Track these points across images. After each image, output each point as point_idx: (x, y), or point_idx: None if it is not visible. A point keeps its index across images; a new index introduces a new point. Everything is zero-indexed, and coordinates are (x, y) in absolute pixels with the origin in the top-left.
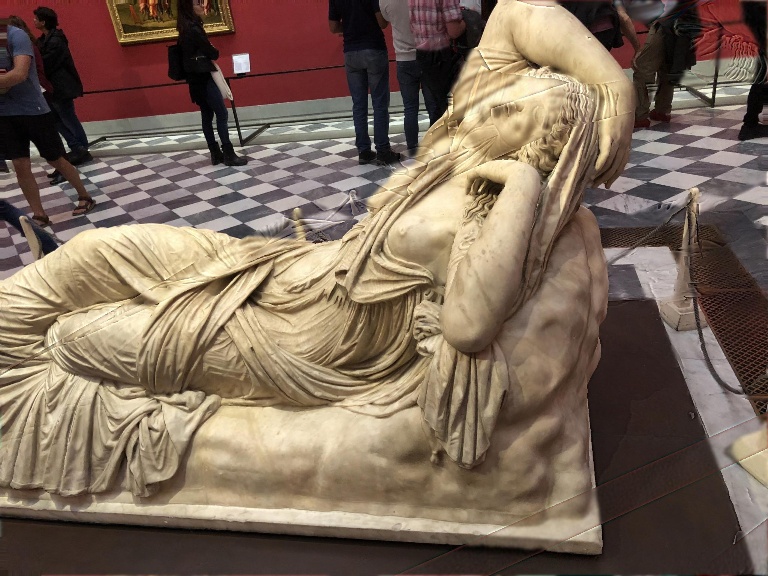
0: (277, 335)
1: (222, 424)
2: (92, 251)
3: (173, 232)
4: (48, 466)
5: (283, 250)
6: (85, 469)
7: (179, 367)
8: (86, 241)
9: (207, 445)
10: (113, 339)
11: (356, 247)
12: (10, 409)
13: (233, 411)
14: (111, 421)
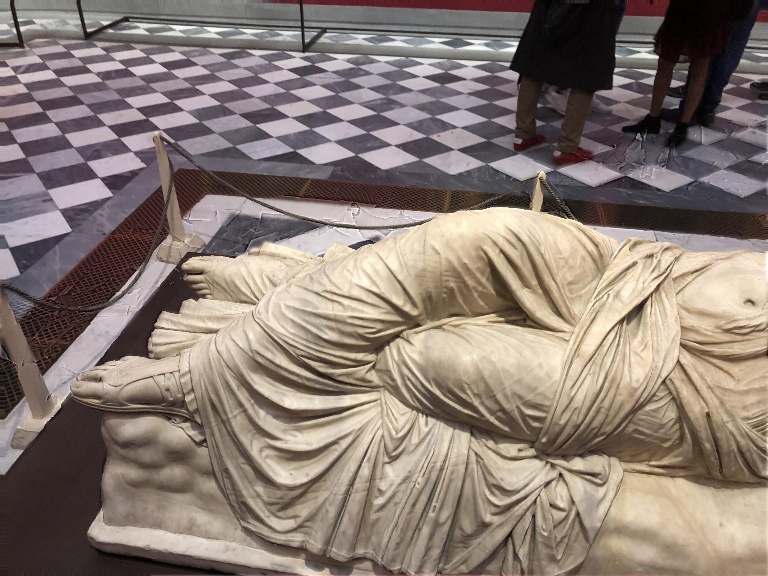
0: (721, 392)
1: (640, 504)
2: (474, 249)
3: (552, 225)
4: (399, 541)
5: (673, 260)
6: (443, 545)
7: (605, 429)
8: (466, 234)
9: (621, 531)
10: (520, 384)
11: None
12: (328, 452)
13: (641, 482)
14: (494, 490)
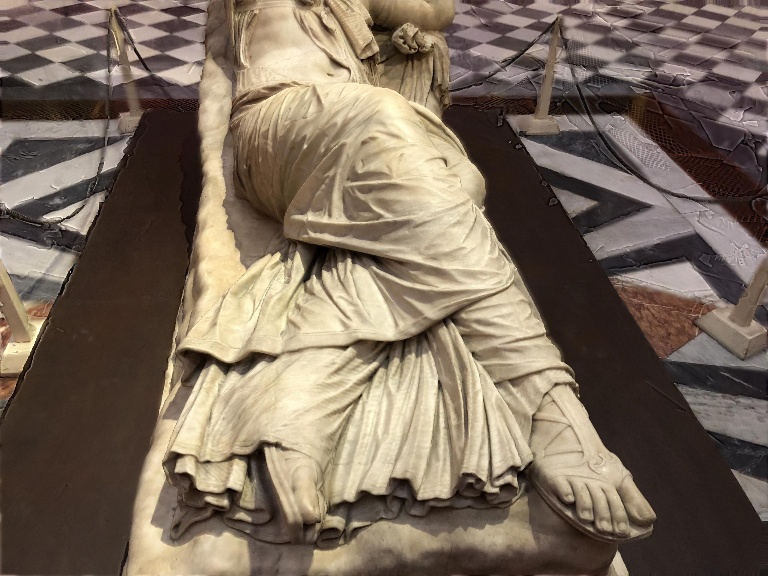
0: None
1: None
2: None
3: None
4: None
5: None
6: None
7: None
8: None
9: None
10: None
11: (359, 19)
12: None
13: None
14: None
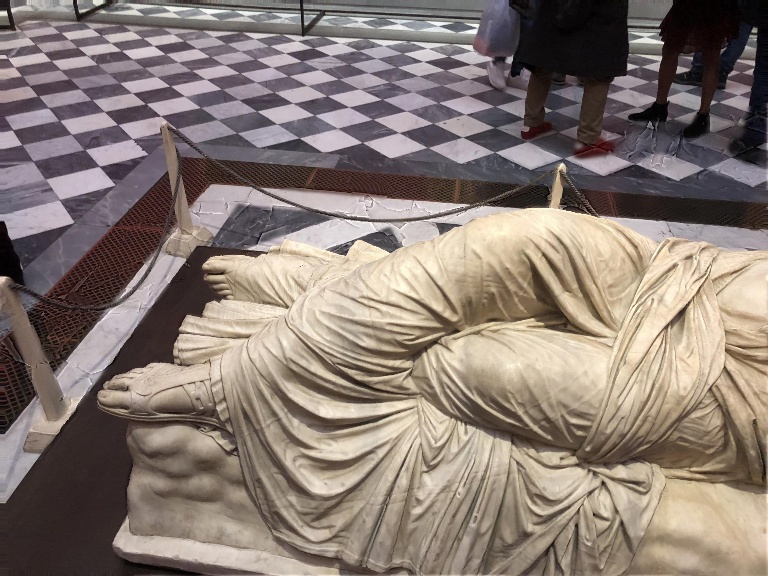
0: None
1: (683, 511)
2: (516, 253)
3: (592, 227)
4: (439, 552)
5: None
6: None
7: (651, 438)
8: (508, 237)
9: (664, 539)
10: (566, 393)
11: None
12: (364, 461)
13: (682, 489)
14: (536, 499)
